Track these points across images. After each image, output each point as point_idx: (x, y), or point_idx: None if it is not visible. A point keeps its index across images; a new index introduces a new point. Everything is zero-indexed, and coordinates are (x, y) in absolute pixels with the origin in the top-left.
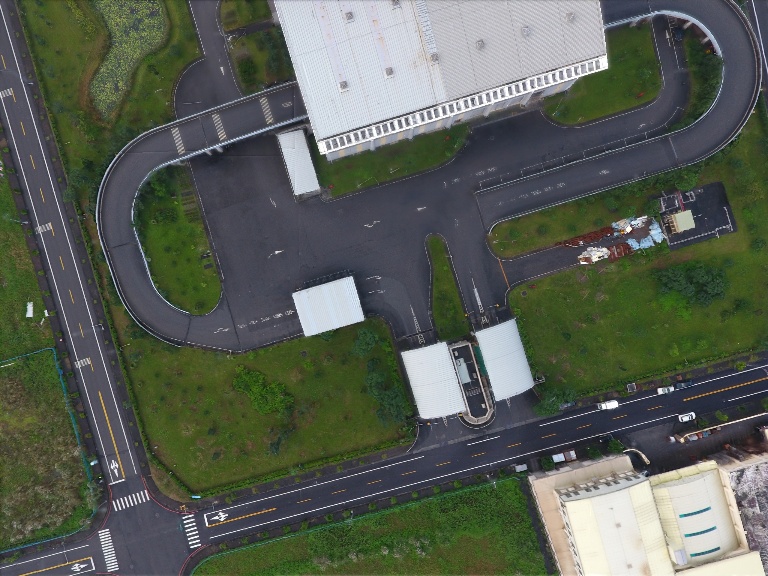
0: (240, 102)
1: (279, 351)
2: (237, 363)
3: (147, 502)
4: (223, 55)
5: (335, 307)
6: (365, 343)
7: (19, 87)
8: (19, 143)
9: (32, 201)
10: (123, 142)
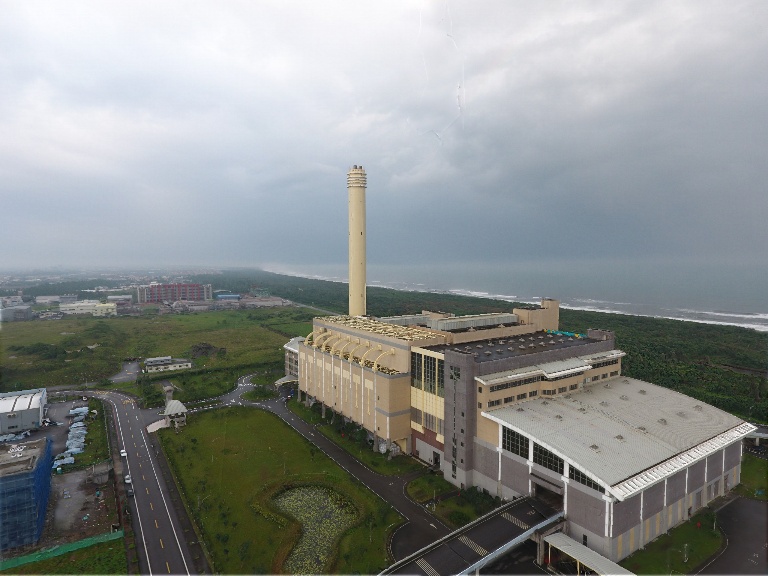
0: (482, 521)
1: None
2: None
3: None
4: (427, 516)
5: None
6: None
7: None
8: None
9: None
10: None
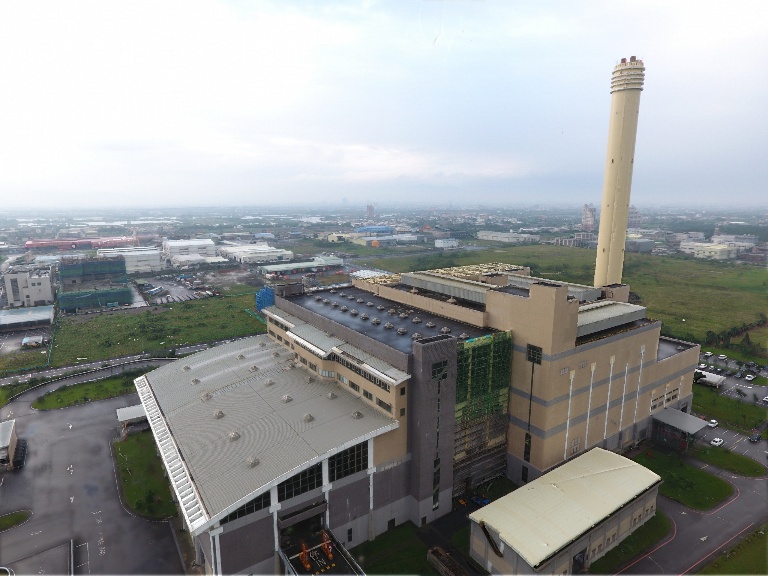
0: None
1: None
2: None
3: None
4: None
5: None
6: None
7: None
8: None
9: None
10: None
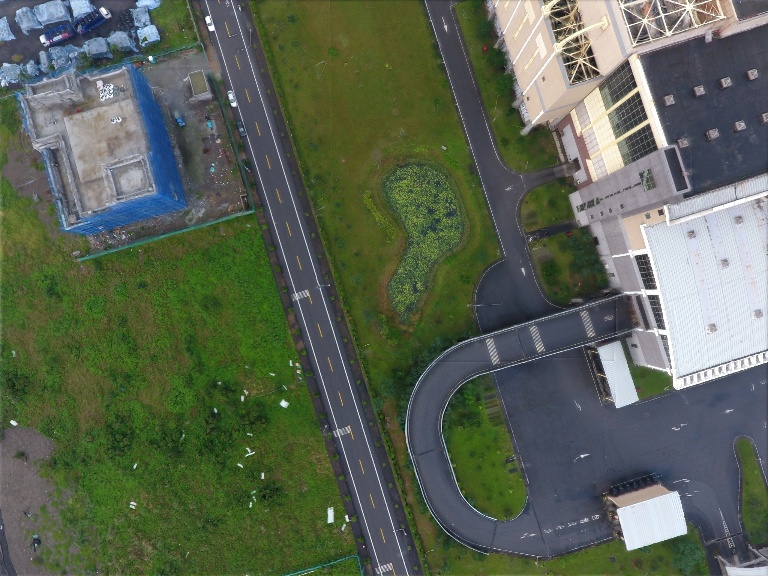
0: (560, 315)
1: (587, 557)
2: (545, 570)
3: None
4: (524, 256)
5: (659, 522)
6: (692, 559)
7: (315, 288)
8: (316, 345)
9: (330, 404)
10: (437, 353)
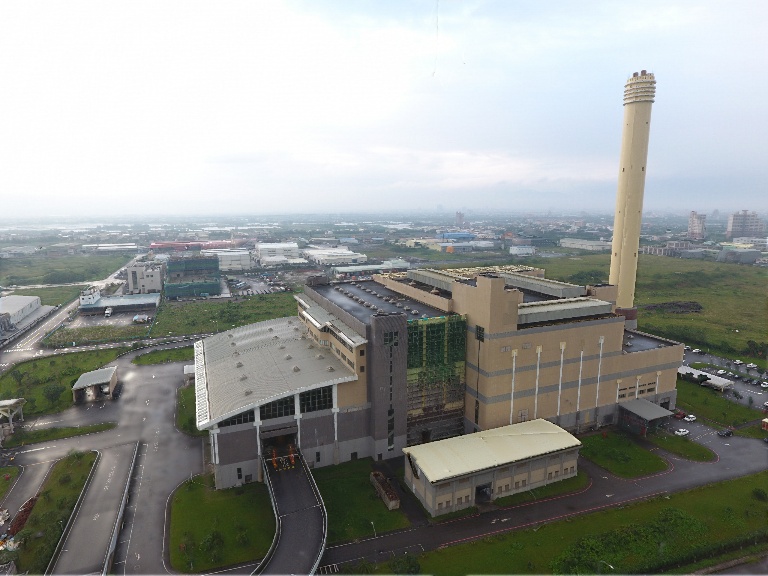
0: None
1: None
2: None
3: (33, 356)
4: None
5: None
6: None
7: None
8: None
9: None
10: None
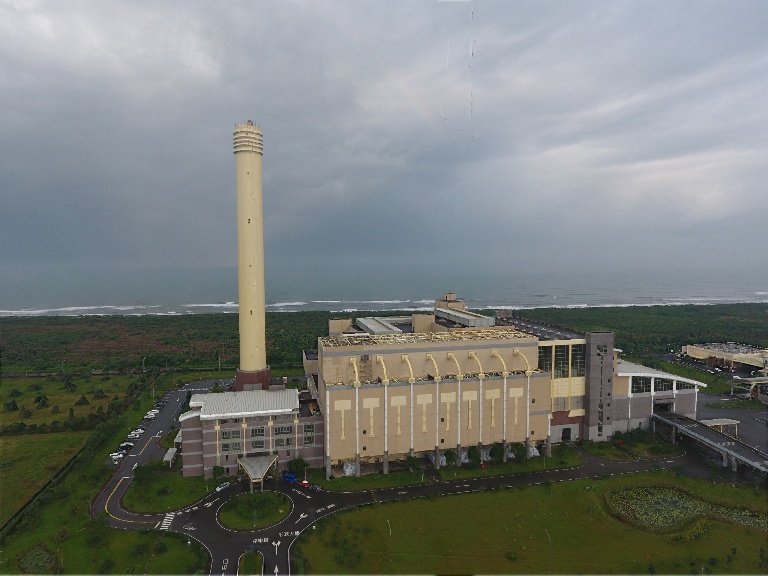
0: None
1: None
2: None
3: None
4: None
5: None
6: None
7: None
8: None
9: None
10: None
